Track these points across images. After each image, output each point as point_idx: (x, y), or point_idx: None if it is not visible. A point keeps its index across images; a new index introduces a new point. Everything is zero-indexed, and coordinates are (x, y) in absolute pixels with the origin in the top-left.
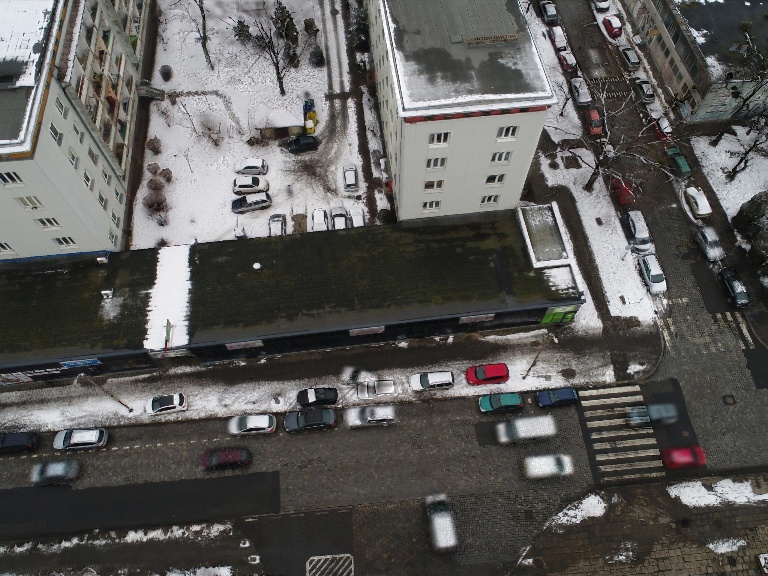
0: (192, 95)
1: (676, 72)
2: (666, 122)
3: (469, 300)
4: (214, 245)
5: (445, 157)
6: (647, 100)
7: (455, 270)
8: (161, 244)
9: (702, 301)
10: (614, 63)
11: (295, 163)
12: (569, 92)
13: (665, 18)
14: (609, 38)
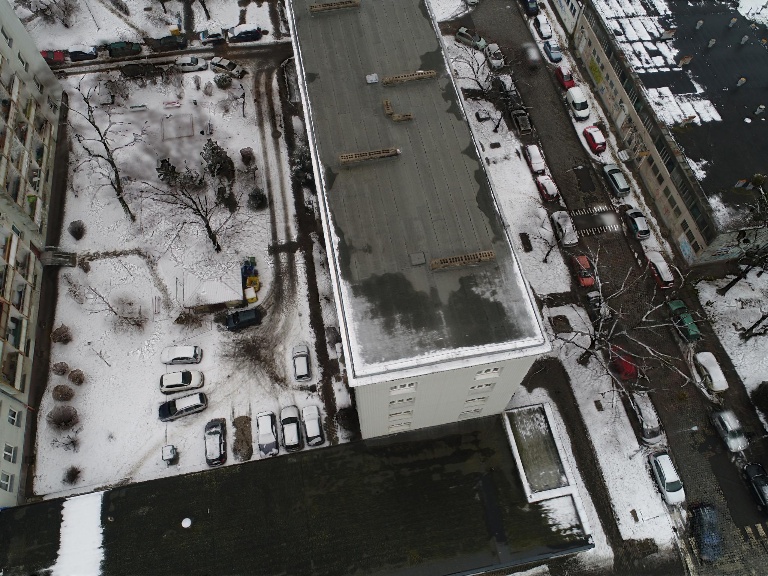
0: (109, 257)
1: (673, 204)
2: (666, 268)
3: (452, 554)
4: (133, 490)
5: (412, 397)
6: (641, 237)
7: (433, 508)
8: (71, 474)
9: (727, 510)
10: (600, 187)
11: (235, 344)
12: (552, 228)
13: (656, 140)
14: (592, 154)
